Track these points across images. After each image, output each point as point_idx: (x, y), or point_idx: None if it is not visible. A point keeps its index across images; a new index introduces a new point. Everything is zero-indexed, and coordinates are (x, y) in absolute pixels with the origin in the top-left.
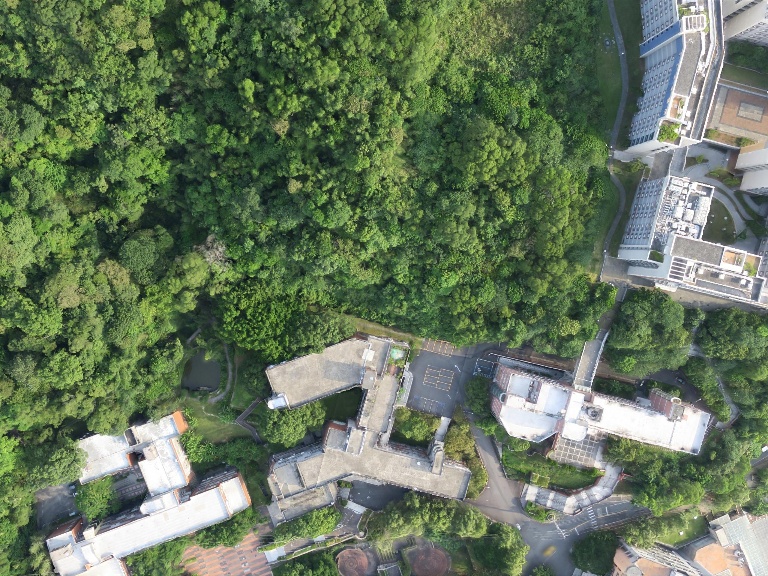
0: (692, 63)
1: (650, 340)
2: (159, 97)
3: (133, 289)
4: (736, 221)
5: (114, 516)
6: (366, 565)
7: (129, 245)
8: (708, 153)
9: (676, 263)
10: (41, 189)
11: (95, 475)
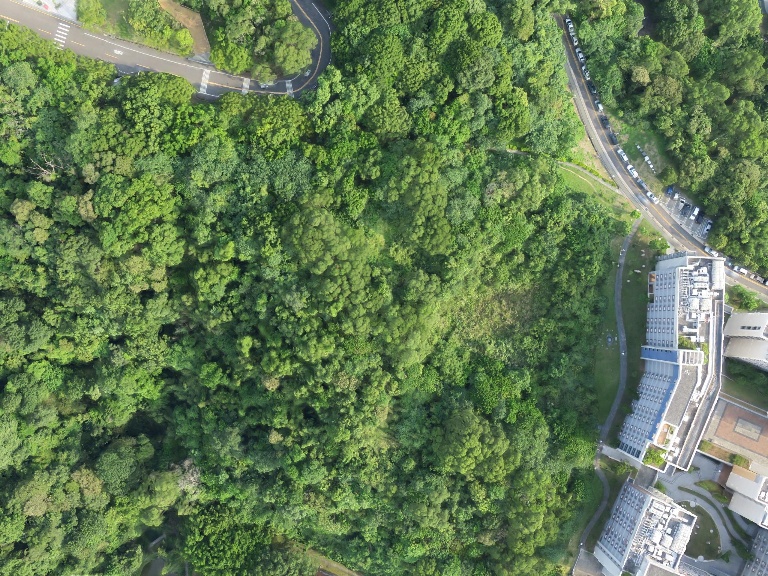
0: (686, 394)
1: None
2: (164, 326)
3: (103, 498)
4: (722, 536)
5: None
6: None
7: (107, 458)
8: (700, 461)
9: None
10: (35, 393)
11: None
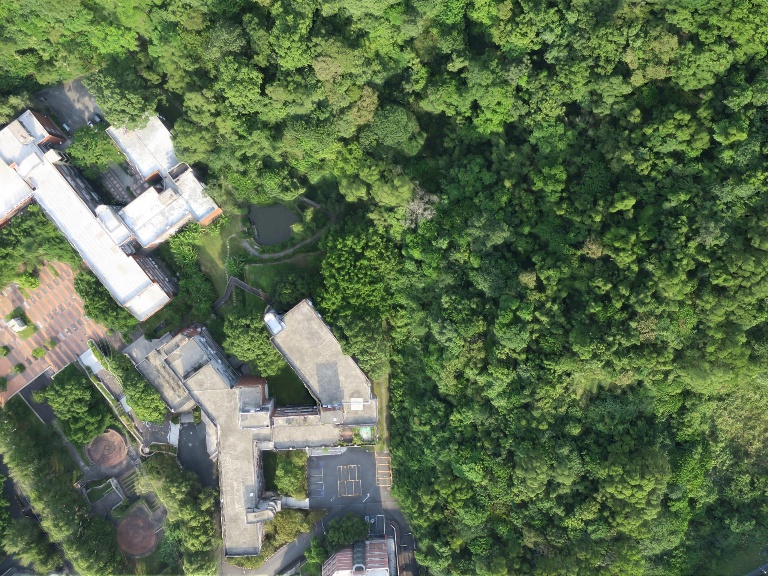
0: None
1: None
2: (575, 103)
3: (351, 130)
4: None
5: (80, 175)
6: (111, 464)
7: (401, 114)
8: None
9: None
10: (435, 3)
11: (122, 143)
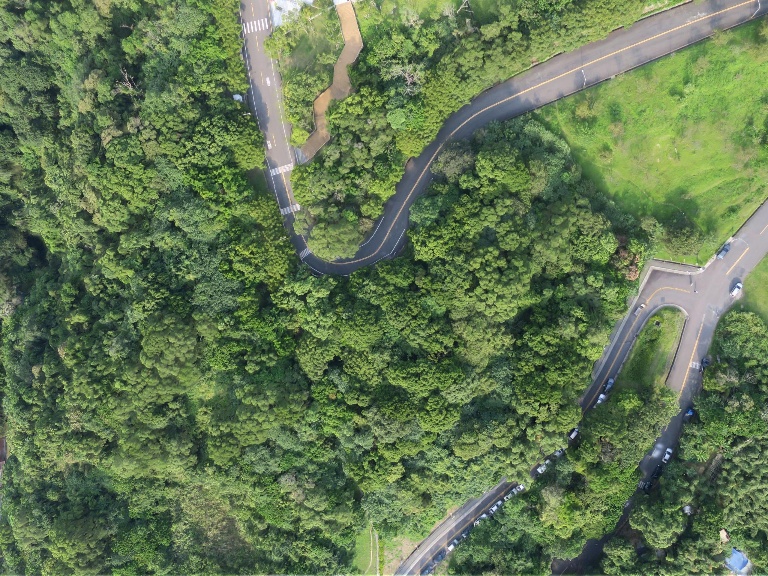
0: None
1: None
2: None
3: None
4: None
5: None
6: None
7: None
8: None
9: None
10: (6, 156)
11: None
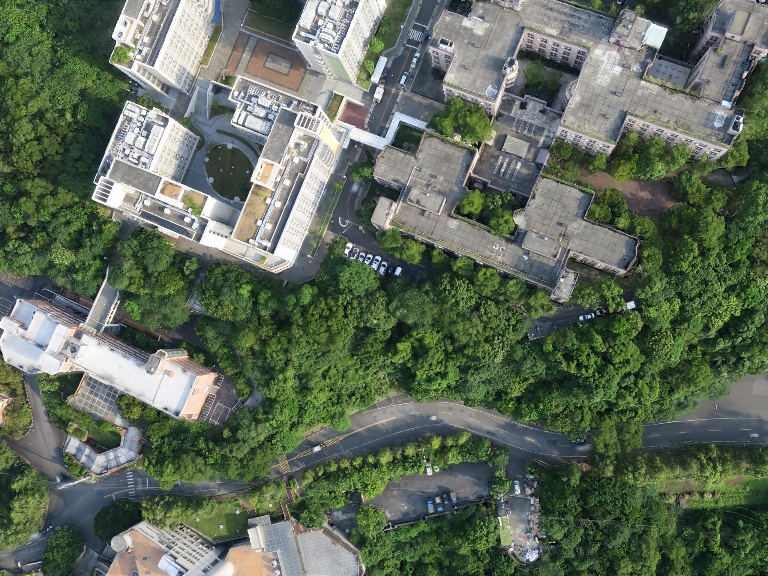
0: None
1: (141, 283)
2: None
3: None
4: None
5: None
6: None
7: None
8: None
9: (104, 184)
10: None
11: None
